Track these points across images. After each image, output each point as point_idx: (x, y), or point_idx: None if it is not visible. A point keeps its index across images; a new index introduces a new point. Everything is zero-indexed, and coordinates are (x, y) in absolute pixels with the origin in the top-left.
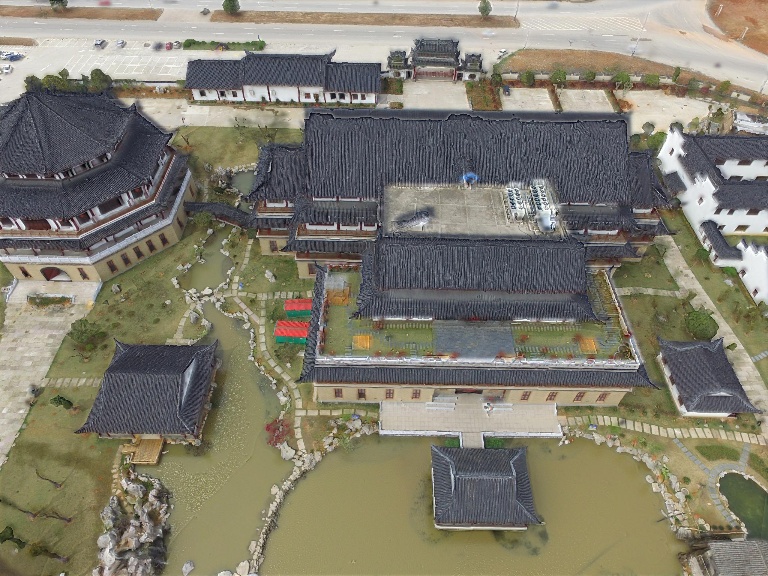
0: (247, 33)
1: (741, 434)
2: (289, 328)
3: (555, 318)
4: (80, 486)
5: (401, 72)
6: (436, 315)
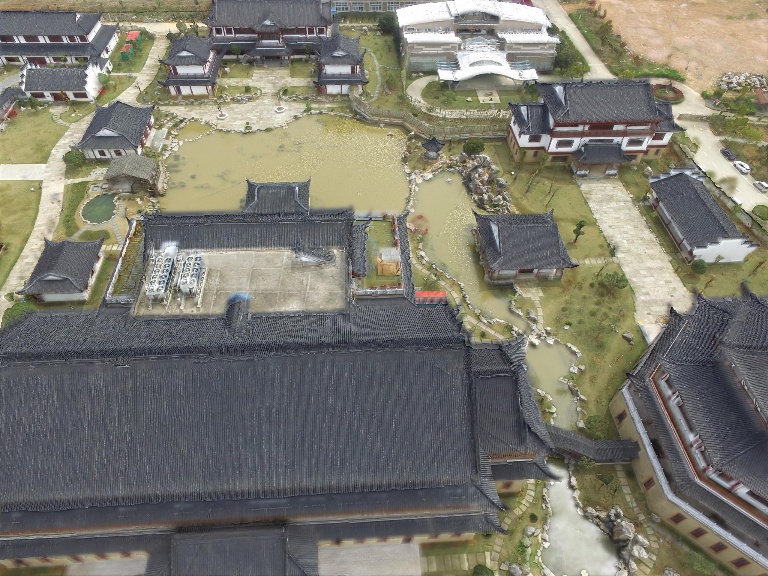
0: None
1: None
2: (434, 296)
3: None
4: (535, 206)
5: None
6: None
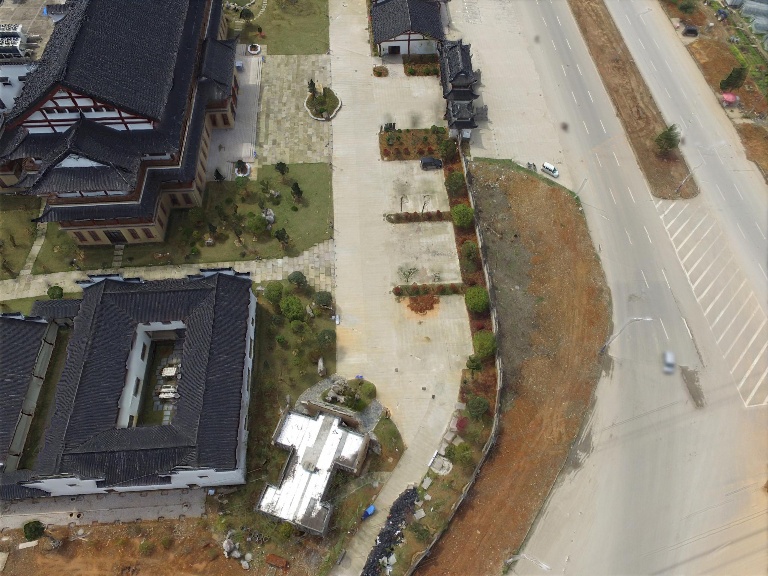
0: None
1: None
2: None
3: None
4: None
5: None
6: None
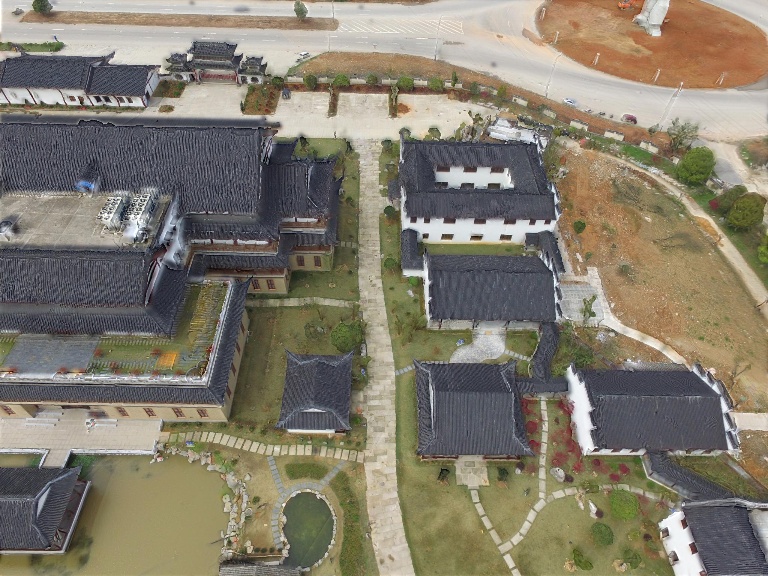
0: (52, 34)
1: (342, 451)
2: None
3: (126, 332)
4: None
5: (183, 75)
6: (1, 329)
